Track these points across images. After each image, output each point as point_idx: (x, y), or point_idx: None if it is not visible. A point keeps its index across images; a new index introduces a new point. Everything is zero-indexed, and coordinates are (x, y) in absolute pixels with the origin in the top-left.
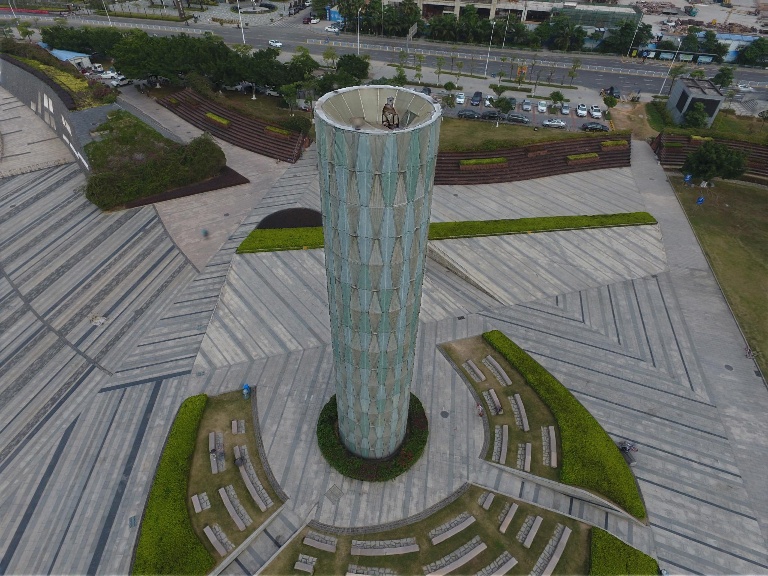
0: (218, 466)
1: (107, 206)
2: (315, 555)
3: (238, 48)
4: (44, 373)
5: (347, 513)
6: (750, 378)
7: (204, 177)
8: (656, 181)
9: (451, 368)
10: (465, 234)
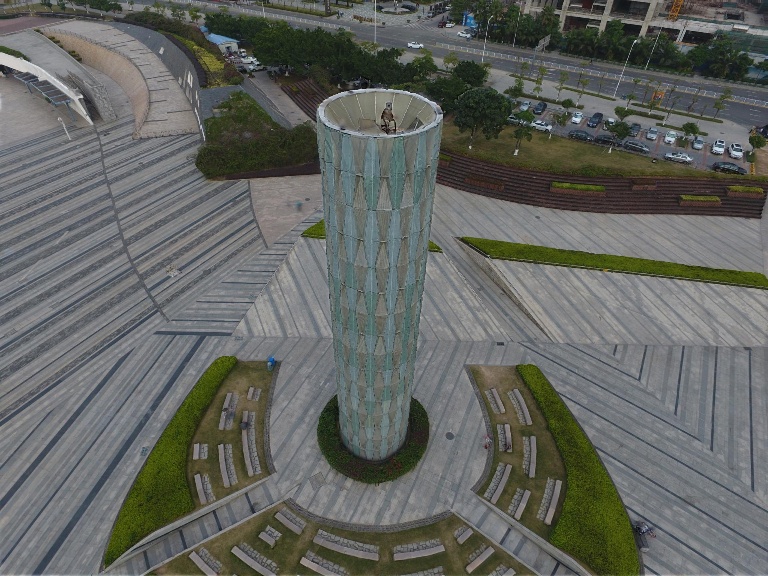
0: (226, 424)
1: (211, 175)
2: (281, 531)
3: (366, 45)
4: (119, 307)
5: (323, 502)
6: None
7: (299, 162)
8: None
9: (472, 392)
10: (531, 259)
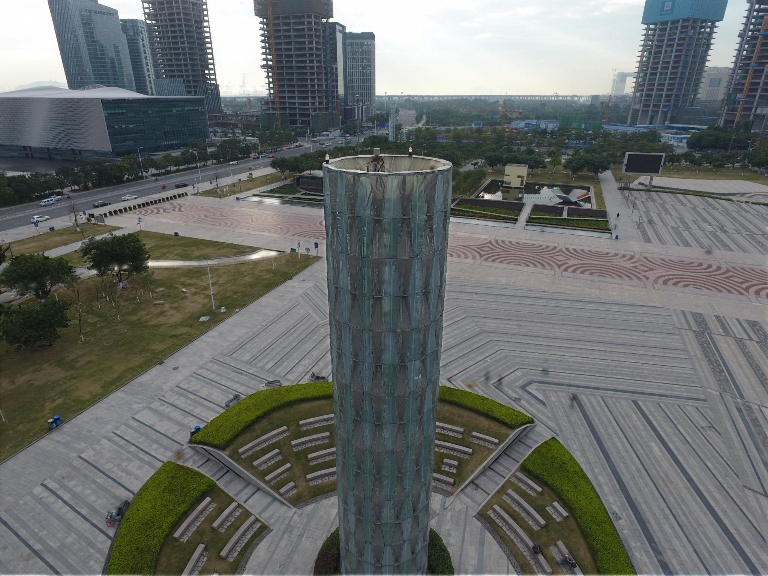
0: (560, 552)
1: None
2: (443, 471)
3: None
4: None
5: None
6: None
7: None
8: None
9: None
10: None
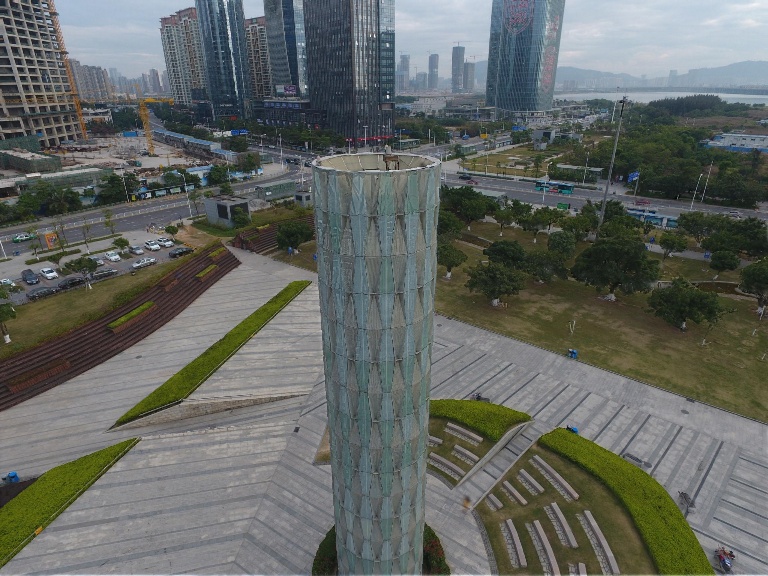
0: None
1: None
2: None
3: None
4: None
5: None
6: (451, 323)
7: None
8: (269, 263)
9: None
10: (209, 371)
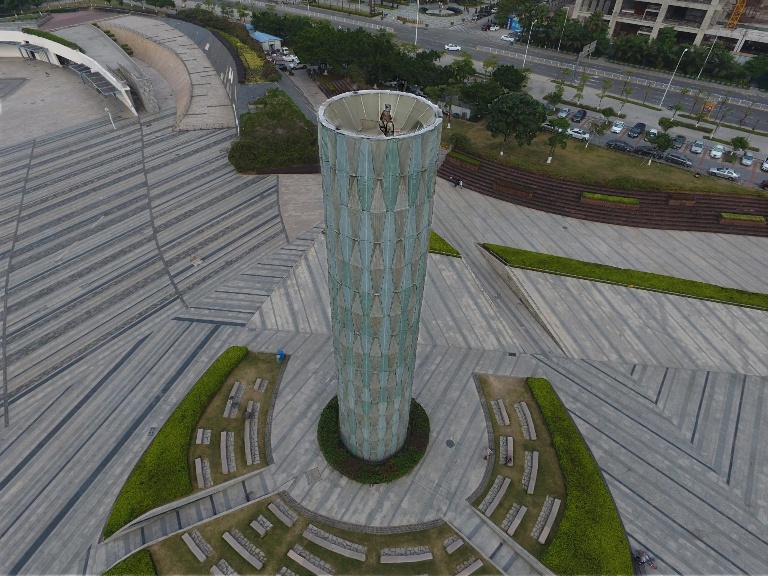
0: (231, 412)
1: (242, 169)
2: (273, 522)
3: (406, 47)
4: (143, 291)
5: (317, 498)
6: None
7: None
8: None
9: (478, 401)
10: (553, 270)
